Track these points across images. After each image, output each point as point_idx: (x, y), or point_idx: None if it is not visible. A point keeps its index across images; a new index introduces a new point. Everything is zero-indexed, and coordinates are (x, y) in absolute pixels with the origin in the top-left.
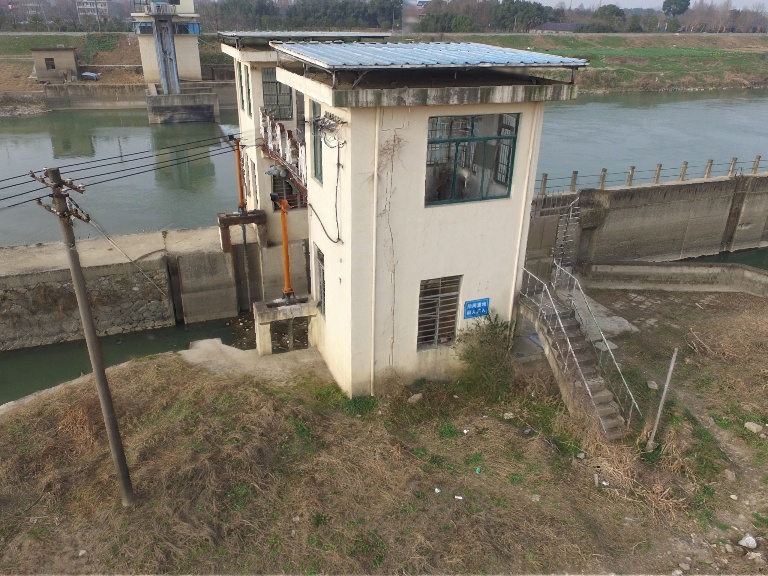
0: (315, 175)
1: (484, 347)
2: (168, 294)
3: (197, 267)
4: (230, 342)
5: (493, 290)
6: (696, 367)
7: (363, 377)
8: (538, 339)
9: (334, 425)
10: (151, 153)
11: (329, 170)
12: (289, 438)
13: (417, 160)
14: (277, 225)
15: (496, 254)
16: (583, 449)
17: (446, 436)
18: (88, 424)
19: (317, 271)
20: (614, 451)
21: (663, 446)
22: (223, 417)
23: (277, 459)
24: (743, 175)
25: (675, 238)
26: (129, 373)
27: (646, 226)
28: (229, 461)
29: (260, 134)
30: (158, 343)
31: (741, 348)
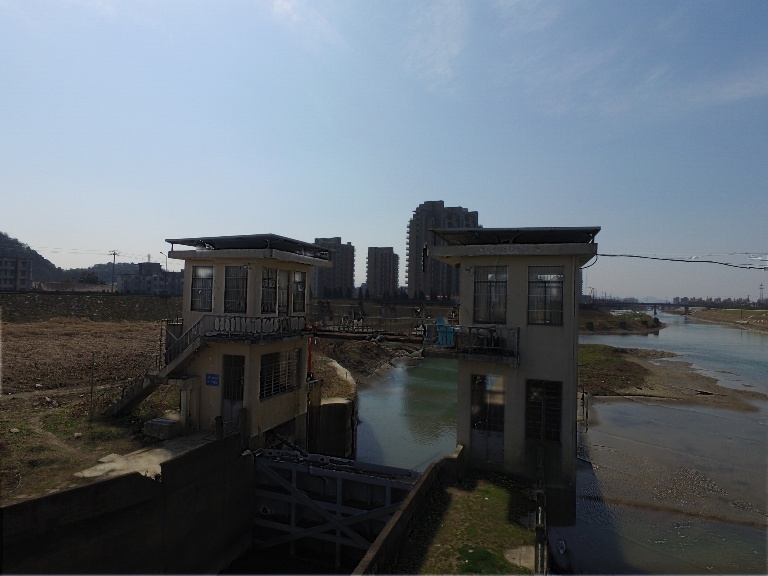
0: None
1: None
2: None
3: None
4: None
5: None
6: None
7: None
8: None
9: None
10: None
11: None
12: None
13: None
14: None
15: None
16: None
17: None
18: None
19: None
20: None
21: None
22: None
23: None
24: None
25: None
26: None
27: None
28: None
29: None
30: None
31: None
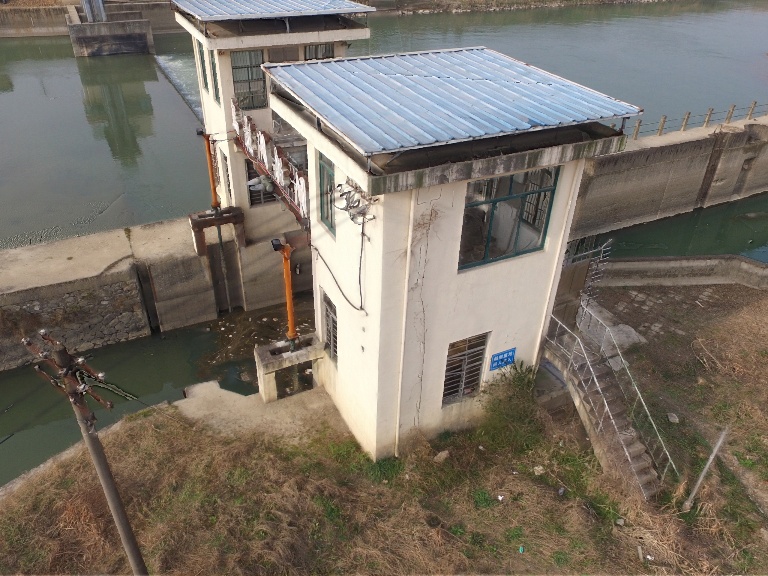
0: (321, 218)
1: (512, 401)
2: (141, 304)
3: (171, 274)
4: (214, 353)
5: (520, 340)
6: (710, 389)
7: (387, 441)
8: (555, 369)
9: (362, 497)
10: (86, 103)
11: (346, 230)
12: (320, 524)
13: (452, 228)
14: (254, 221)
15: (526, 306)
16: (621, 513)
17: (481, 506)
18: (95, 522)
19: (323, 313)
20: (657, 522)
21: (699, 505)
22: (243, 500)
23: (311, 554)
24: (722, 132)
25: (654, 199)
26: (125, 439)
27: (627, 190)
28: (261, 564)
29: (232, 126)
30: (133, 354)
31: (748, 359)
